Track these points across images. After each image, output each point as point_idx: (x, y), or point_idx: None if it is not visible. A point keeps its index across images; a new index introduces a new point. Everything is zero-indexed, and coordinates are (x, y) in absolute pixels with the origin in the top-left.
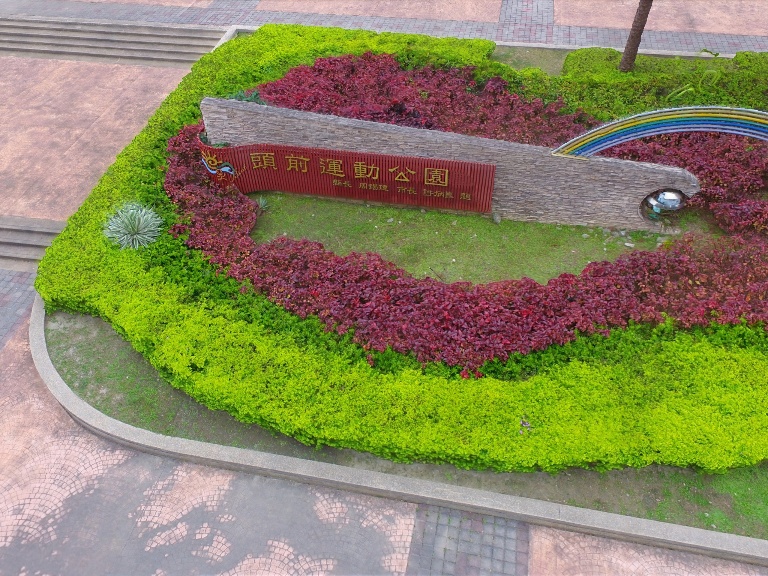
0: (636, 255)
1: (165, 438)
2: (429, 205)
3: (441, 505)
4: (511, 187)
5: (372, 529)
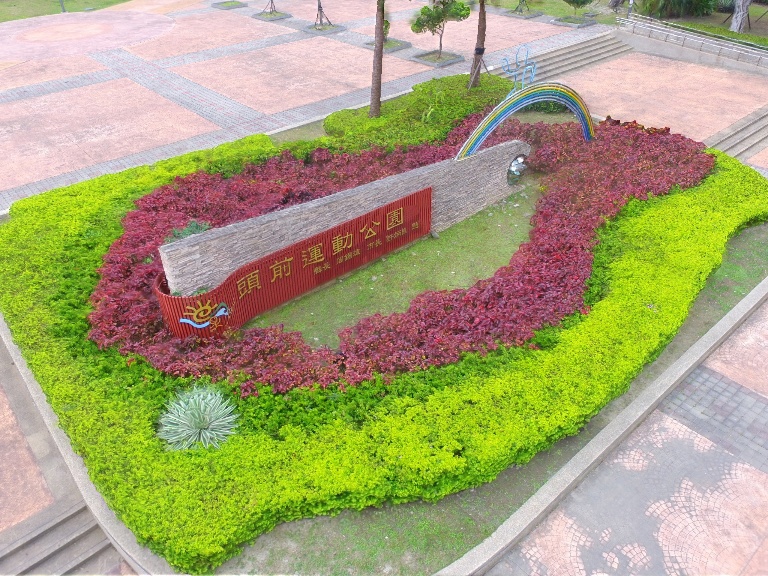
0: (543, 201)
1: (493, 538)
2: (390, 250)
3: (666, 396)
4: (439, 202)
5: (667, 443)
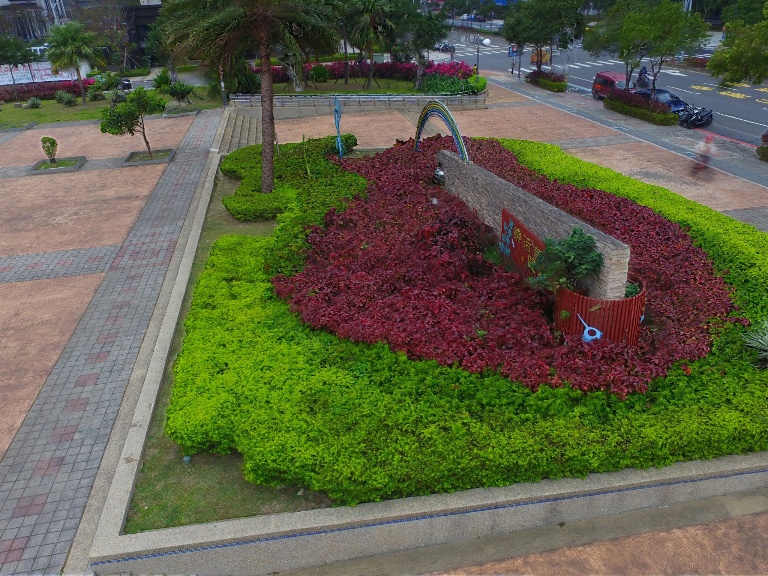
0: None
1: None
2: None
3: None
4: None
5: None
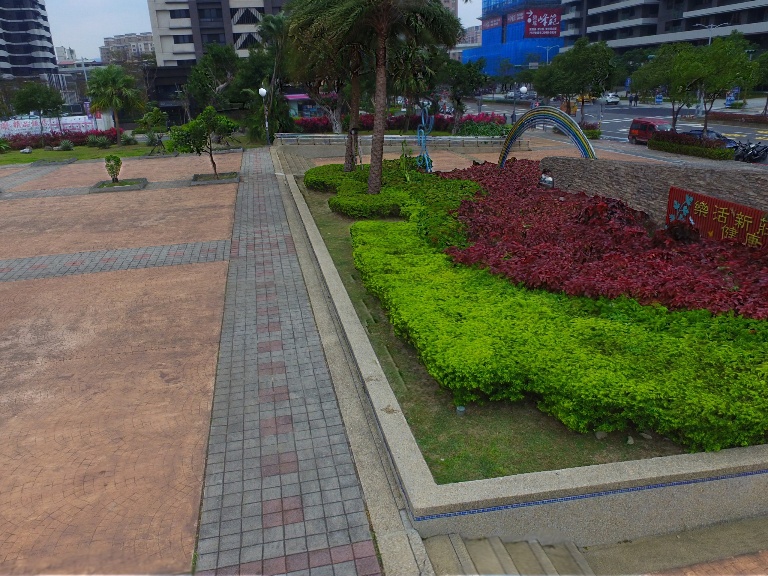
0: None
1: None
2: None
3: None
4: None
5: None
